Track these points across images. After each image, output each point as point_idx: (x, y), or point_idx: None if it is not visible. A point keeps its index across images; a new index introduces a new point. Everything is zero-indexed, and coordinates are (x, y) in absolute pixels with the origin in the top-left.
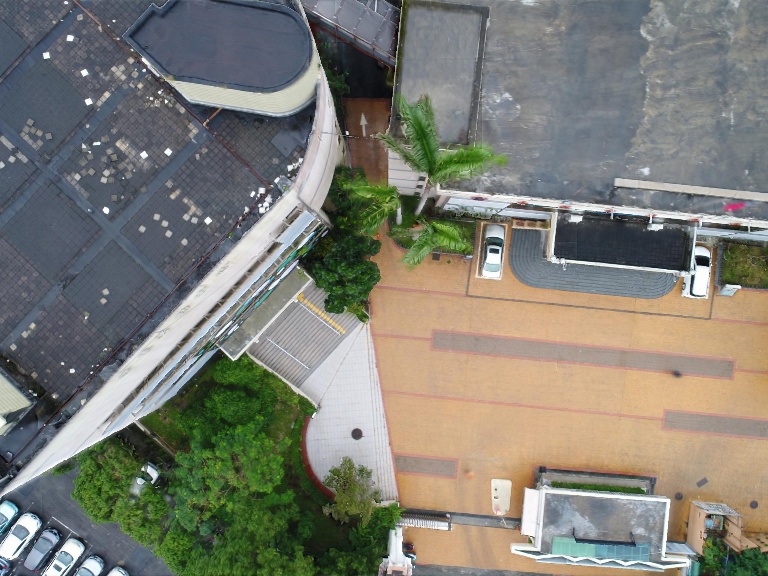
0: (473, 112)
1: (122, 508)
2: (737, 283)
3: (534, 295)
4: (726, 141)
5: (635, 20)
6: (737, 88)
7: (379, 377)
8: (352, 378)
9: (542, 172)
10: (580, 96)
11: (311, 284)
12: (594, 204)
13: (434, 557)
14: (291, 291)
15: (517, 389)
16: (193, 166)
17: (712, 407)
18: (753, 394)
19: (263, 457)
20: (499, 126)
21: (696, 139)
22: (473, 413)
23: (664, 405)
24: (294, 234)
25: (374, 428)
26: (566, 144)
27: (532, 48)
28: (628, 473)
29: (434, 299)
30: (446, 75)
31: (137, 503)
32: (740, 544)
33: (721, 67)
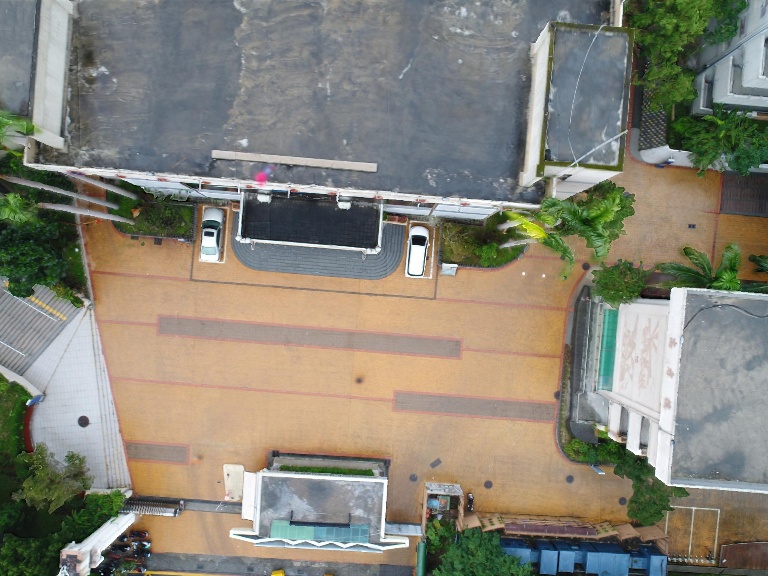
0: (31, 83)
1: None
2: (457, 262)
3: (258, 278)
4: (323, 111)
5: None
6: (332, 59)
7: (106, 363)
8: (77, 365)
9: (140, 145)
10: (176, 69)
11: None
12: (182, 175)
13: (171, 545)
14: None
15: (245, 373)
16: None
17: (442, 387)
18: (482, 373)
19: None
20: (96, 100)
21: (293, 110)
22: (202, 398)
23: (394, 386)
24: None
25: (101, 415)
26: (164, 117)
27: (126, 22)
28: (362, 455)
29: (158, 284)
30: (5, 47)
31: None
32: (462, 524)
33: (315, 38)
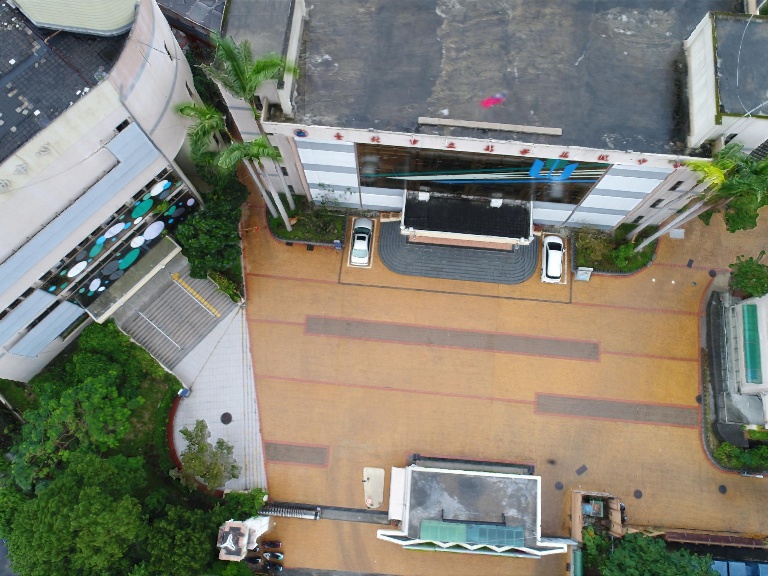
0: (284, 51)
1: None
2: None
3: (402, 282)
4: (512, 89)
5: (431, 3)
6: (518, 50)
7: (252, 361)
8: (225, 361)
9: (356, 113)
10: (388, 57)
11: (187, 265)
12: (397, 132)
13: (304, 559)
14: (159, 258)
15: (388, 372)
16: (31, 72)
17: (583, 390)
18: (621, 376)
19: (109, 407)
20: (320, 79)
21: (487, 88)
22: (345, 397)
23: (535, 388)
24: (131, 155)
25: (244, 412)
26: (377, 92)
27: (348, 23)
28: (505, 461)
29: (308, 286)
30: (264, 26)
31: None
32: (621, 529)
33: (504, 35)
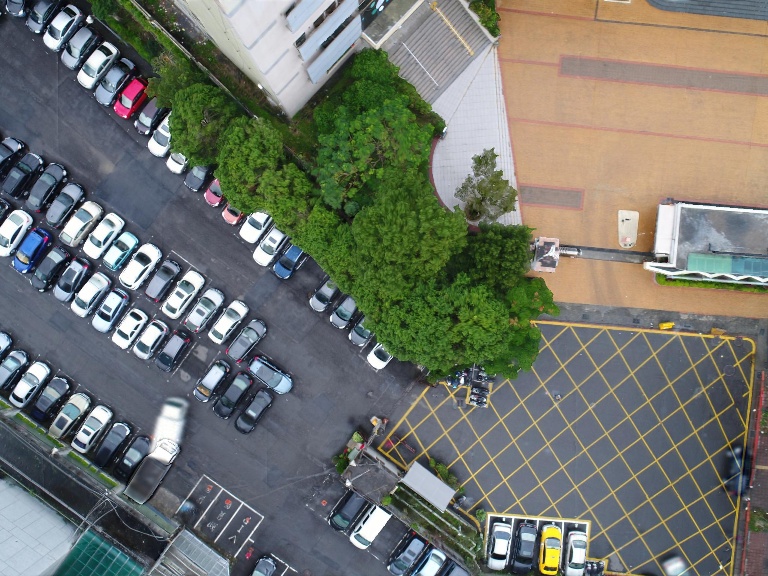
0: None
1: (270, 177)
2: None
3: (664, 19)
4: None
5: None
6: None
7: (505, 104)
8: (479, 103)
9: None
10: None
11: None
12: None
13: (558, 294)
14: None
15: (645, 116)
16: None
17: None
18: None
19: (412, 129)
20: None
21: None
22: (600, 141)
23: None
24: None
25: (500, 155)
26: None
27: None
28: (757, 205)
29: (562, 23)
30: None
31: (283, 177)
32: None
33: None
